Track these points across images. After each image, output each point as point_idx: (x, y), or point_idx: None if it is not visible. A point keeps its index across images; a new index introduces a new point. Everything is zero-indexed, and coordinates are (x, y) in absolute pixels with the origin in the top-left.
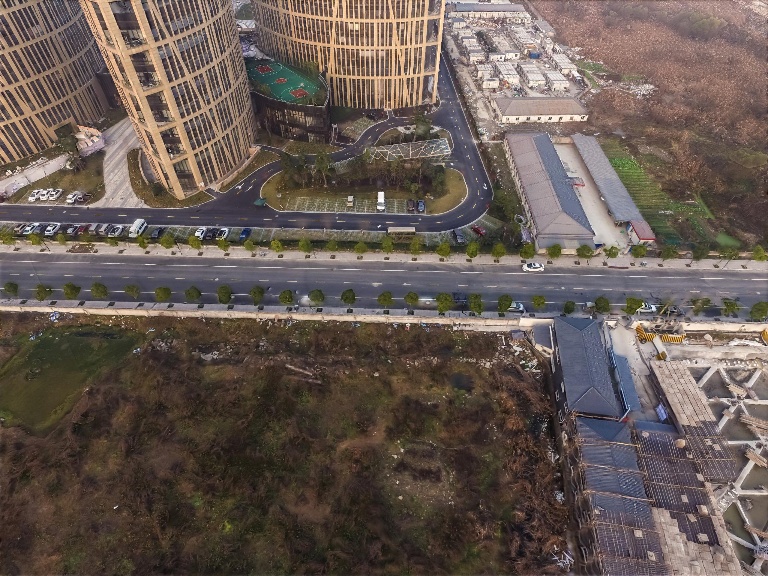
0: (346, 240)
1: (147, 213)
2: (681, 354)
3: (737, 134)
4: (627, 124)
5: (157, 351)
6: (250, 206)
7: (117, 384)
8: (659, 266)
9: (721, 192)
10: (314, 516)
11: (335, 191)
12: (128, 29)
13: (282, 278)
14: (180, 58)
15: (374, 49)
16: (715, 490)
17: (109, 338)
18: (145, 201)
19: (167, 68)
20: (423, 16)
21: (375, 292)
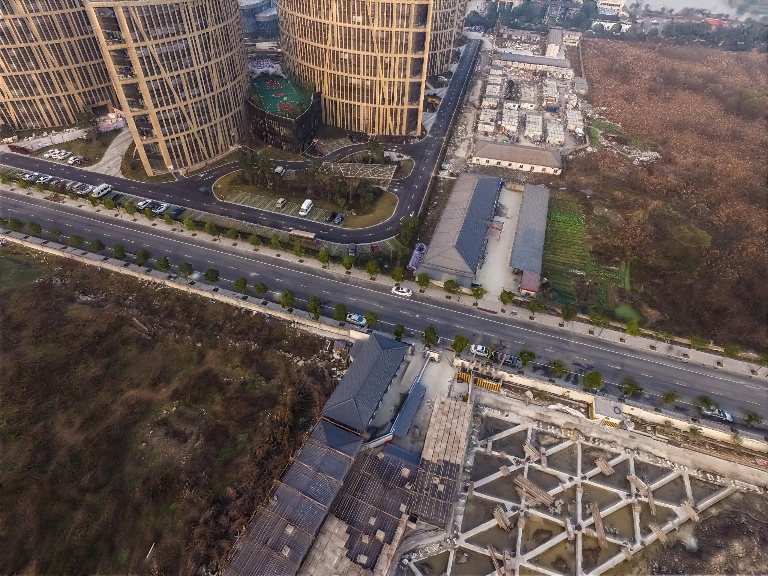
0: (255, 233)
1: (119, 181)
2: (495, 403)
3: (716, 214)
4: (600, 185)
5: (52, 284)
6: (199, 191)
7: (6, 300)
8: (530, 319)
9: (652, 265)
10: (71, 437)
11: (275, 192)
12: (112, 30)
13: (183, 252)
14: (157, 59)
15: (360, 78)
16: (429, 531)
17: (28, 267)
18: (123, 172)
19: (143, 65)
20: (406, 54)
21: (248, 280)
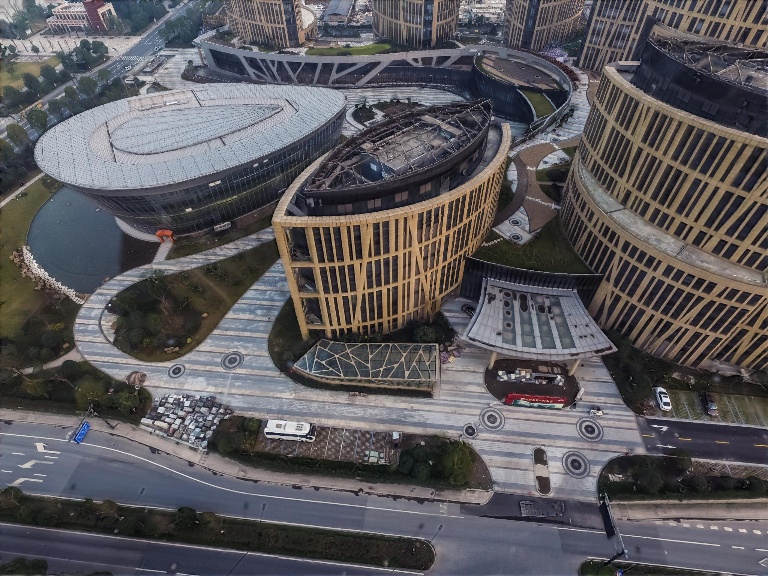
0: None
1: None
2: None
3: None
4: None
5: None
6: None
7: None
8: None
9: None
10: None
11: None
12: None
13: None
14: None
15: None
16: None
17: None
18: None
19: None
20: None
21: None
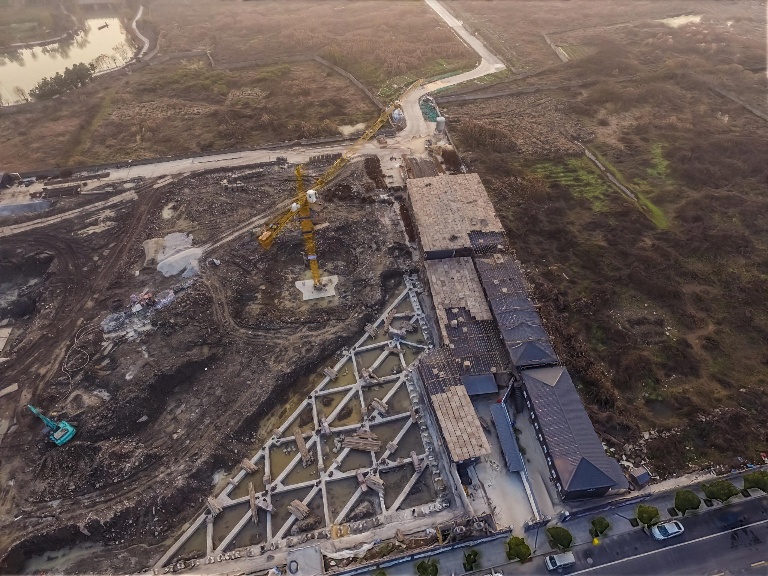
0: None
1: None
2: None
3: None
4: None
5: None
6: None
7: None
8: None
9: None
10: (689, 287)
11: None
12: None
13: None
14: None
15: None
16: None
17: None
18: None
19: None
20: None
21: None
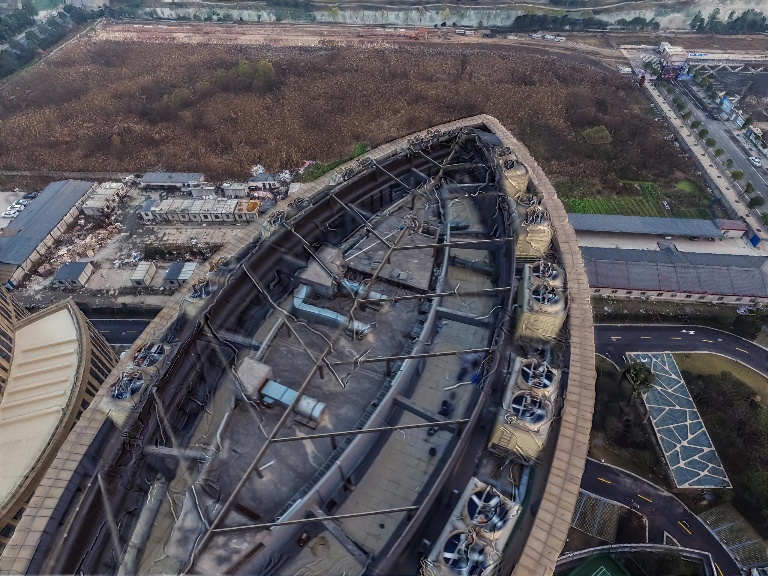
0: None
1: None
2: None
3: None
4: None
5: None
6: None
7: None
8: (761, 232)
9: None
10: None
11: None
12: None
13: None
14: None
15: None
16: None
17: None
18: None
19: None
20: None
21: None
